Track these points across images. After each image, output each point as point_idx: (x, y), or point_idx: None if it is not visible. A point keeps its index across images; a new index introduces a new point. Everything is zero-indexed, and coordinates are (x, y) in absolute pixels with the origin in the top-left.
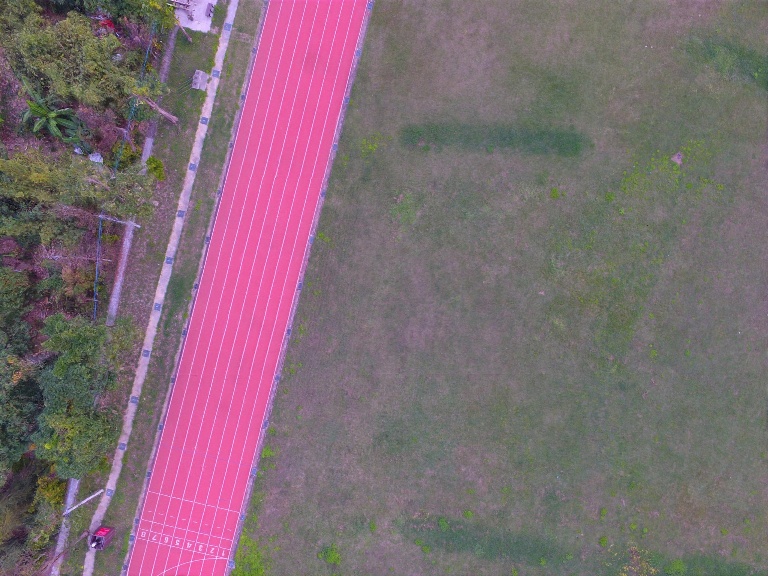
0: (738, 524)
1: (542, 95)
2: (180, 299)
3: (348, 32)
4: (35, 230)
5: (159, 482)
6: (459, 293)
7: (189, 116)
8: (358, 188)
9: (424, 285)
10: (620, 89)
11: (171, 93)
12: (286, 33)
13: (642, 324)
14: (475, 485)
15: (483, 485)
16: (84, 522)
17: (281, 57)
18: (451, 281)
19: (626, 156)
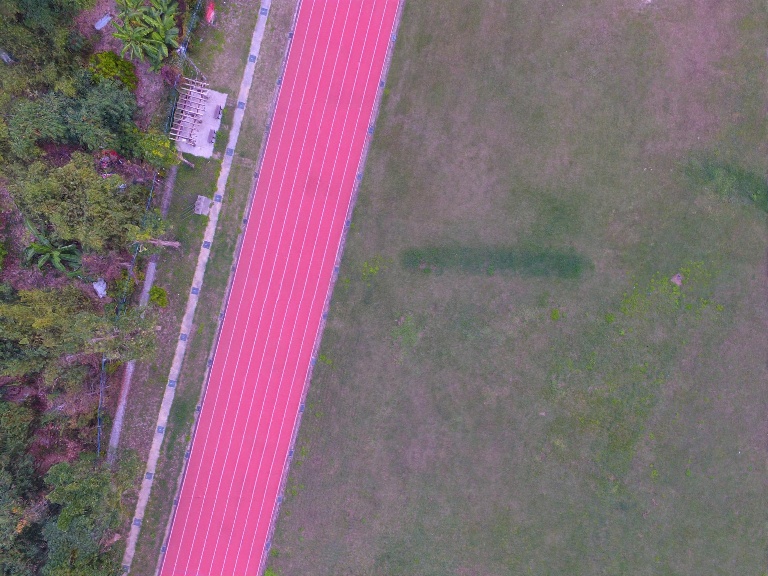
0: None
1: (542, 218)
2: (183, 422)
3: (349, 156)
4: (39, 368)
5: None
6: (460, 414)
7: (191, 241)
8: (359, 310)
9: (425, 406)
10: (620, 211)
11: (174, 218)
12: (288, 158)
13: (643, 444)
14: None
15: None
16: None
17: (283, 181)
18: (452, 402)
19: (626, 277)
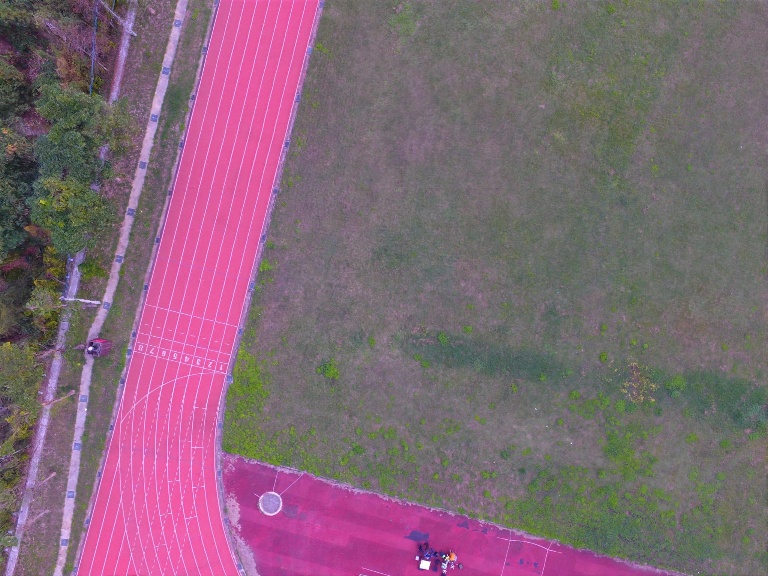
0: (739, 340)
1: None
2: (177, 110)
3: None
4: (29, 18)
5: (156, 295)
6: (459, 106)
7: None
8: None
9: (423, 97)
10: None
11: None
12: None
13: (643, 138)
14: (475, 300)
15: (483, 300)
16: (81, 335)
17: None
18: (451, 93)
19: None
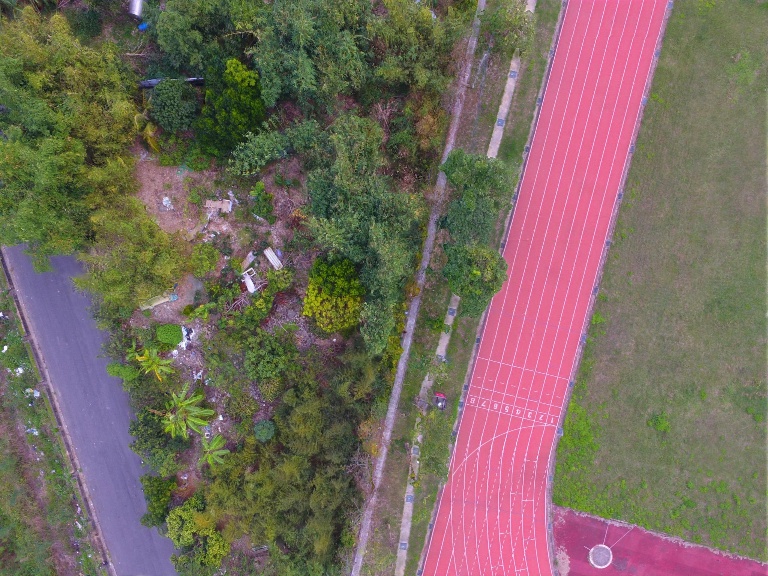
0: None
1: None
2: None
3: None
4: (402, 76)
5: (489, 348)
6: None
7: None
8: (694, 47)
9: (760, 148)
10: None
11: None
12: None
13: None
14: None
15: None
16: (414, 387)
17: None
18: None
19: None
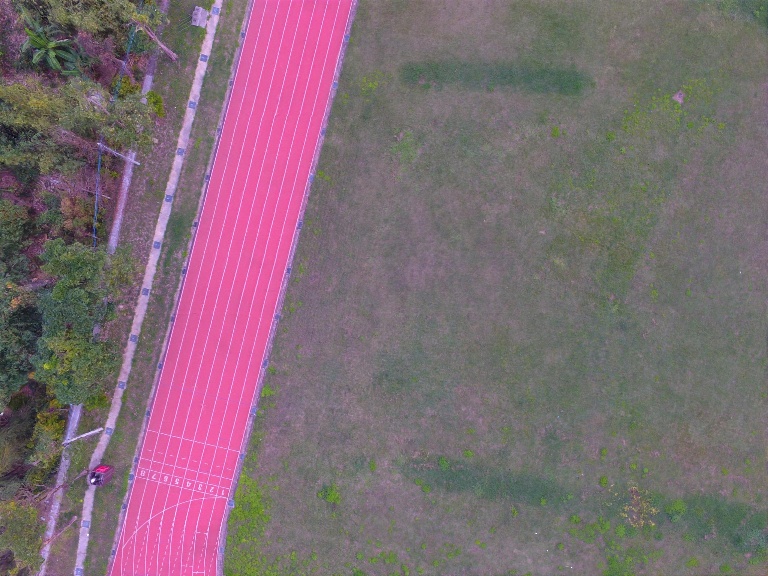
0: (739, 464)
1: (543, 33)
2: (180, 237)
3: None
4: (34, 161)
5: (158, 421)
6: (459, 232)
7: (189, 53)
8: (358, 126)
9: (424, 224)
10: (621, 27)
11: (171, 30)
12: None
13: (643, 264)
14: (475, 425)
15: (483, 425)
16: (83, 460)
17: None
18: (451, 220)
19: (627, 95)
